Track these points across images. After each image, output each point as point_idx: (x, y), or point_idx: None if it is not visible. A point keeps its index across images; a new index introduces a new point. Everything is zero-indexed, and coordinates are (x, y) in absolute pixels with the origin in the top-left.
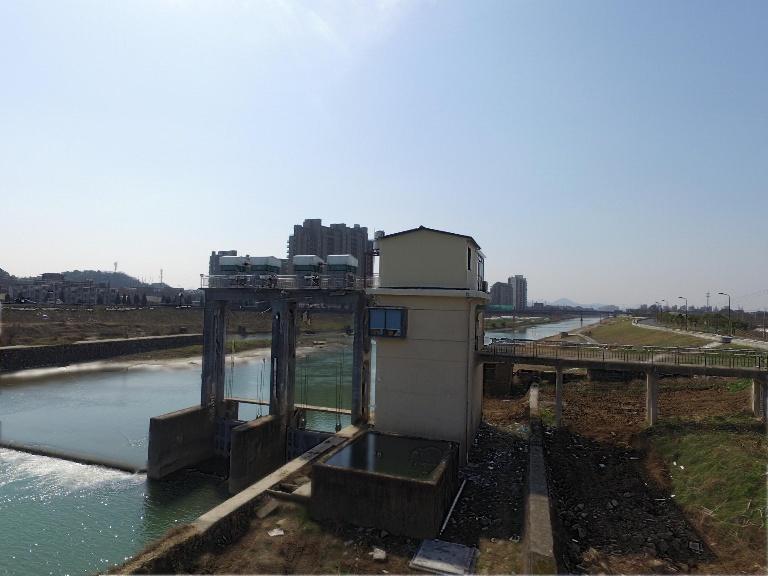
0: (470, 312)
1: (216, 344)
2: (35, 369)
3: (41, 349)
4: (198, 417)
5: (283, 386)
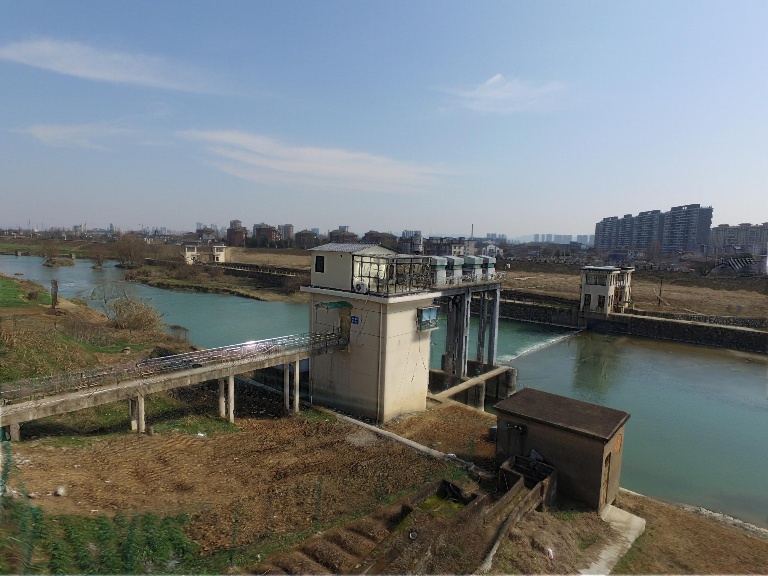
0: (314, 302)
1: (488, 321)
2: (737, 351)
3: (759, 335)
4: (469, 366)
5: (448, 354)
